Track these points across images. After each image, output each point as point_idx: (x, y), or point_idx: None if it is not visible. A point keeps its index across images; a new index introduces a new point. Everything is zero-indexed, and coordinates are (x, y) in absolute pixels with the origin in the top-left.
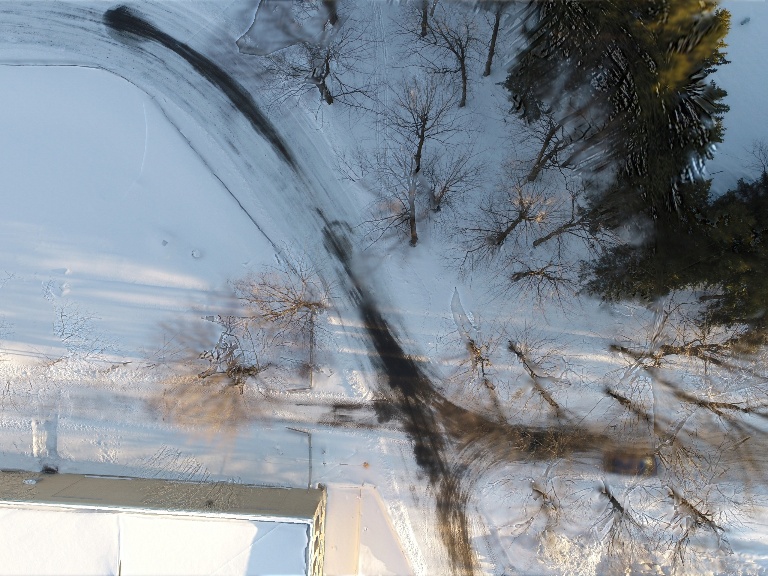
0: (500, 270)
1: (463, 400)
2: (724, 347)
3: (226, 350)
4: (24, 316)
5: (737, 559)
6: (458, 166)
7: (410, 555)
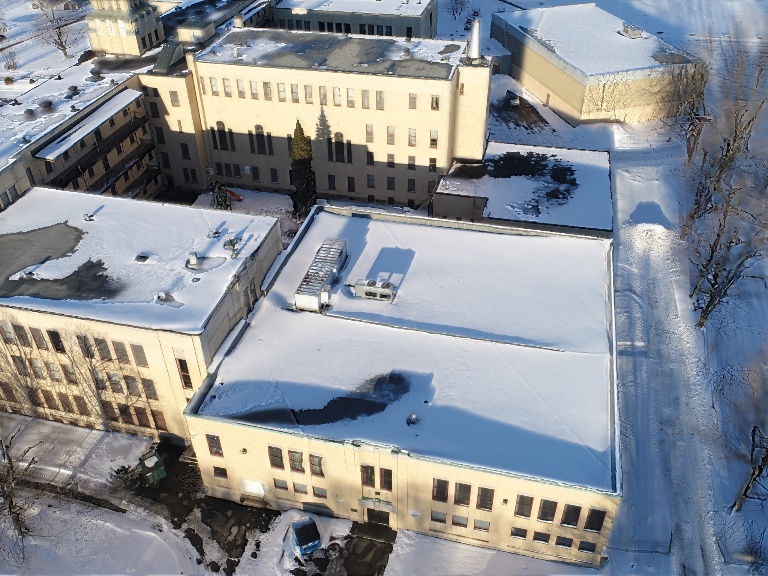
0: None
1: None
2: None
3: None
4: (740, 348)
5: None
6: None
7: None
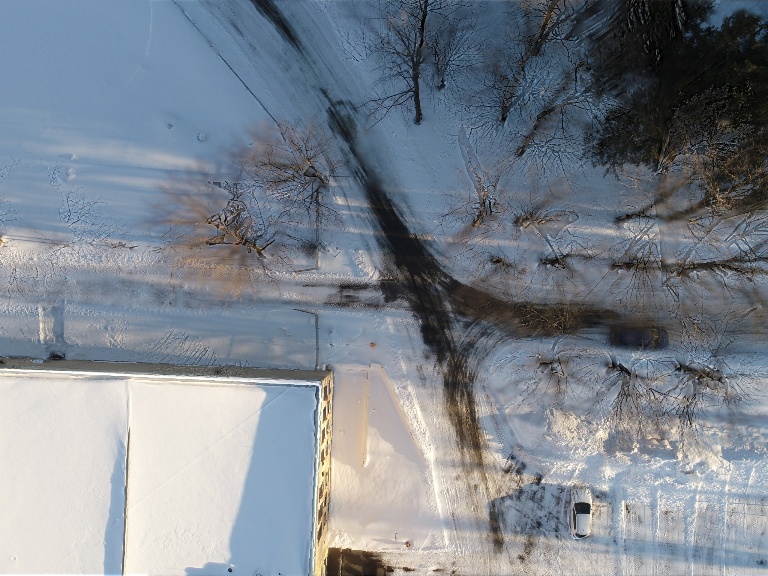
0: (504, 146)
1: (469, 277)
2: (731, 144)
3: (233, 212)
4: (30, 202)
5: (744, 433)
6: (461, 40)
7: (418, 435)
